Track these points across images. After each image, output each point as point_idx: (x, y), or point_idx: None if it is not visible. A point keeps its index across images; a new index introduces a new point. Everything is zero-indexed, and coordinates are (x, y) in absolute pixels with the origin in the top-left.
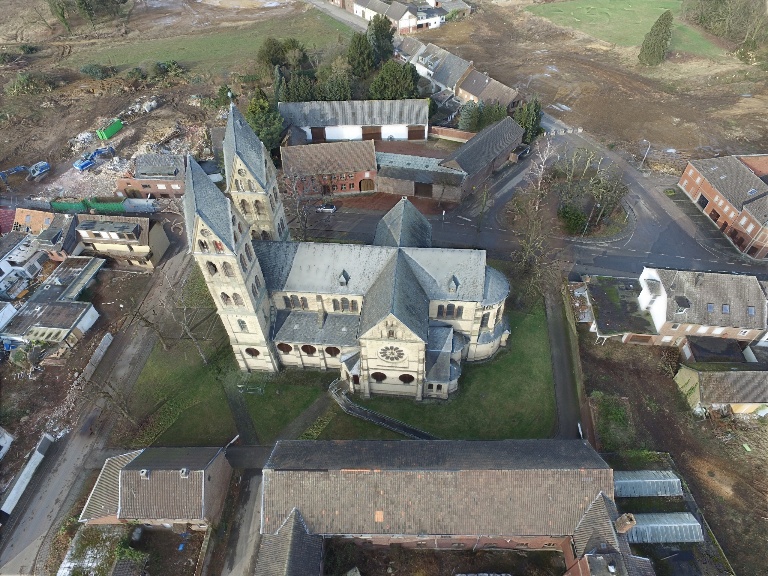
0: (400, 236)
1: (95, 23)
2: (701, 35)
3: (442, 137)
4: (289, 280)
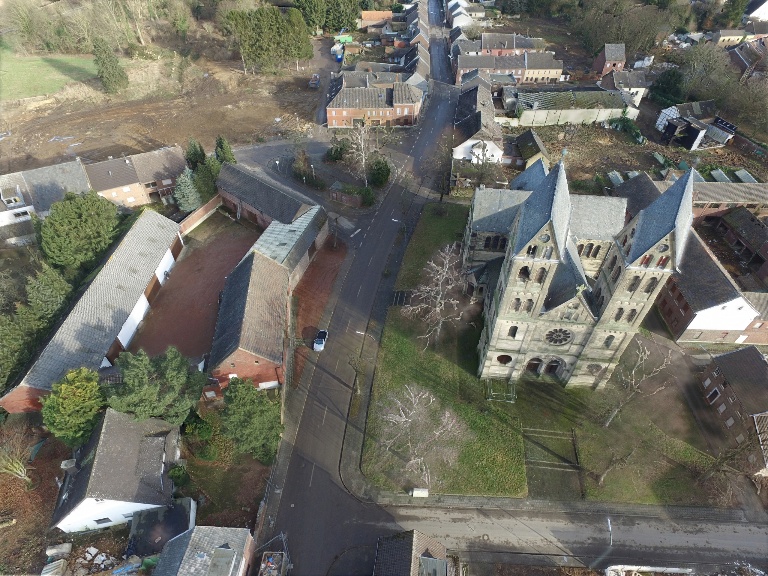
0: None
1: None
2: (77, 58)
3: (187, 232)
4: (582, 276)
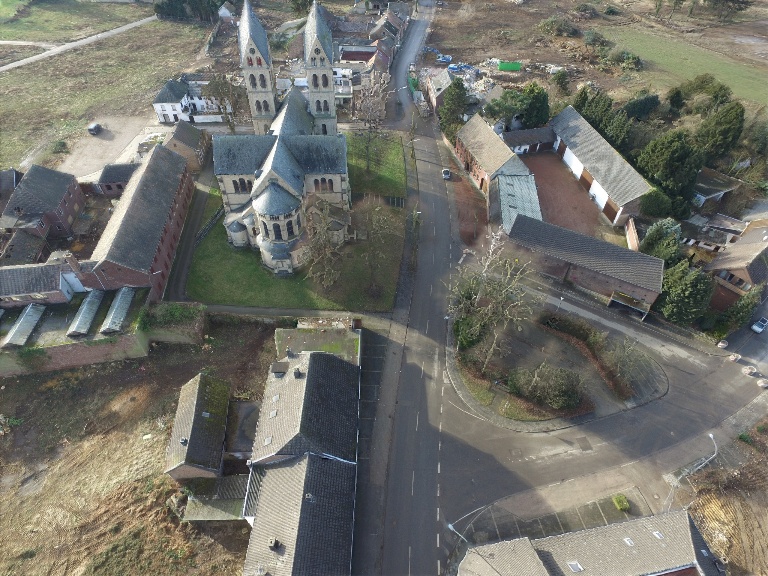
0: (292, 135)
1: (694, 17)
2: None
3: None
4: None
